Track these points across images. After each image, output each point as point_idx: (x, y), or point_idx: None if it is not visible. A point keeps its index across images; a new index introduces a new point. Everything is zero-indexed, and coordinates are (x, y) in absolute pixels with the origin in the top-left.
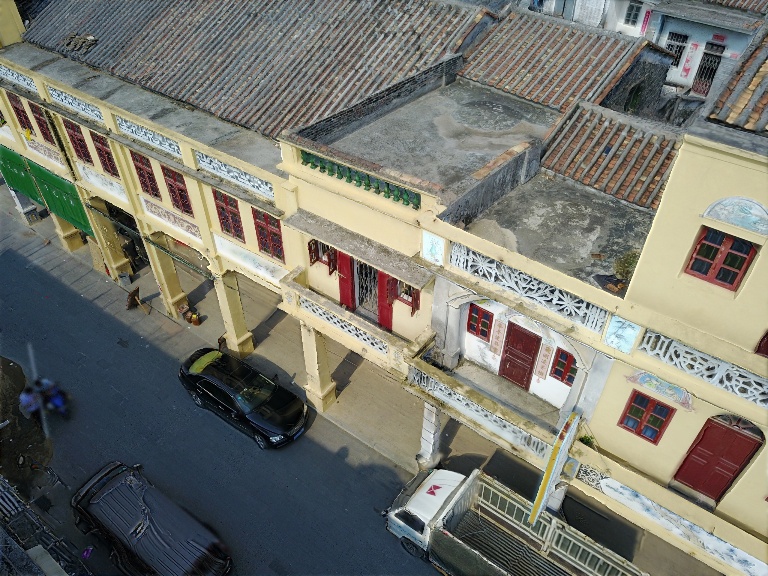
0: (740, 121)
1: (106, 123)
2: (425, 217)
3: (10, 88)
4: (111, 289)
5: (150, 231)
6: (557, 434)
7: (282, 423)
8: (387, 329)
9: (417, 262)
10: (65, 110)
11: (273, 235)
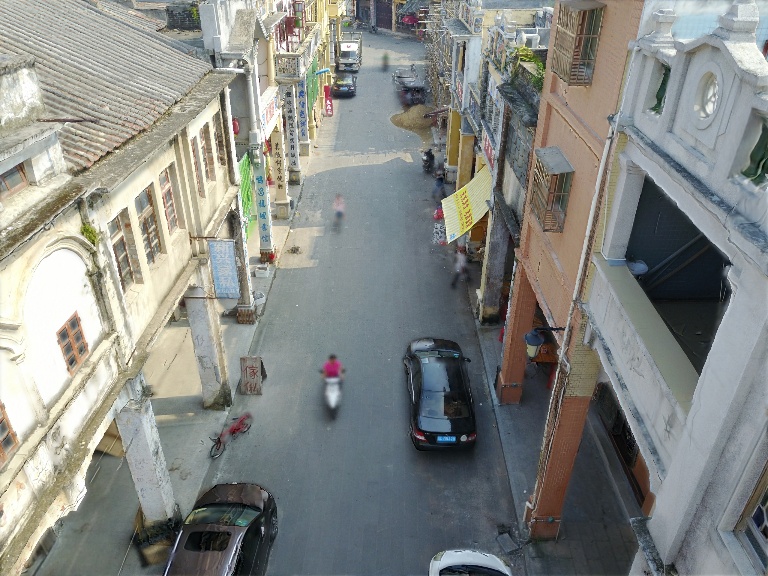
0: None
1: None
2: None
3: (312, 0)
4: None
5: None
6: None
7: None
8: None
9: None
10: None
11: None
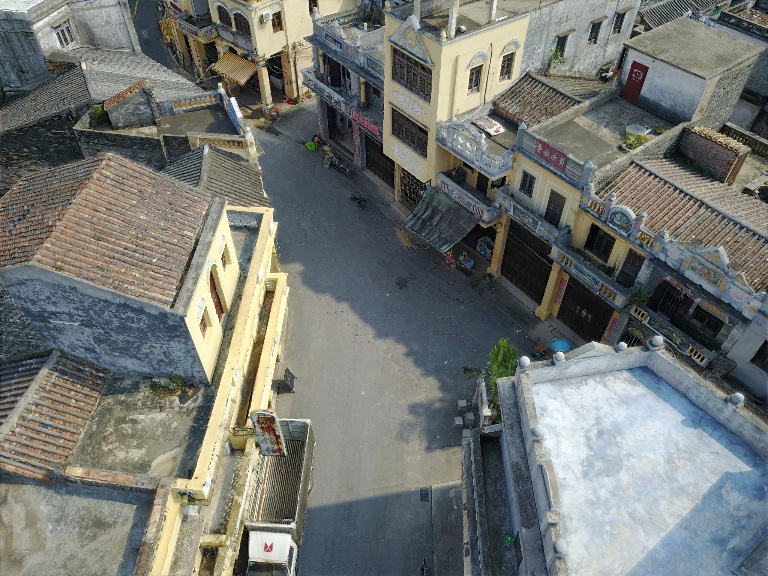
0: (172, 297)
1: None
2: (195, 485)
3: None
4: None
5: None
6: (233, 453)
7: None
8: None
9: None
10: None
11: None
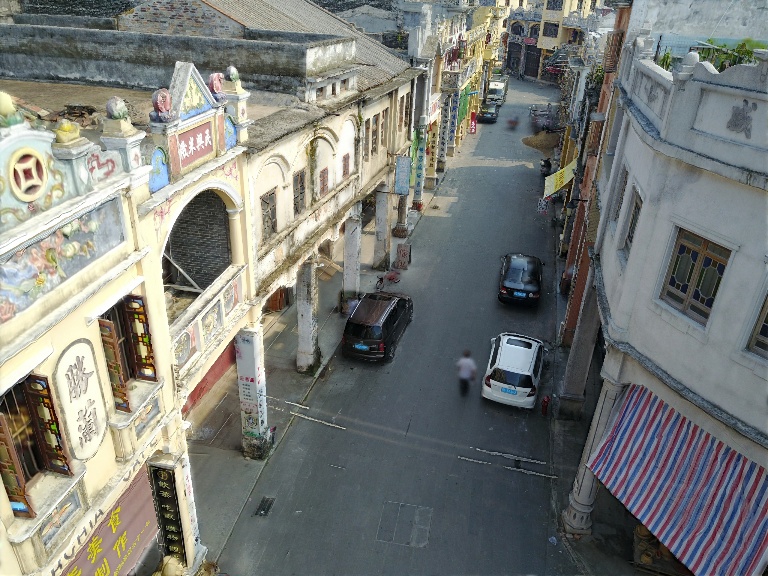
0: None
1: None
2: None
3: None
4: None
5: None
6: None
7: None
8: None
9: None
10: None
11: None
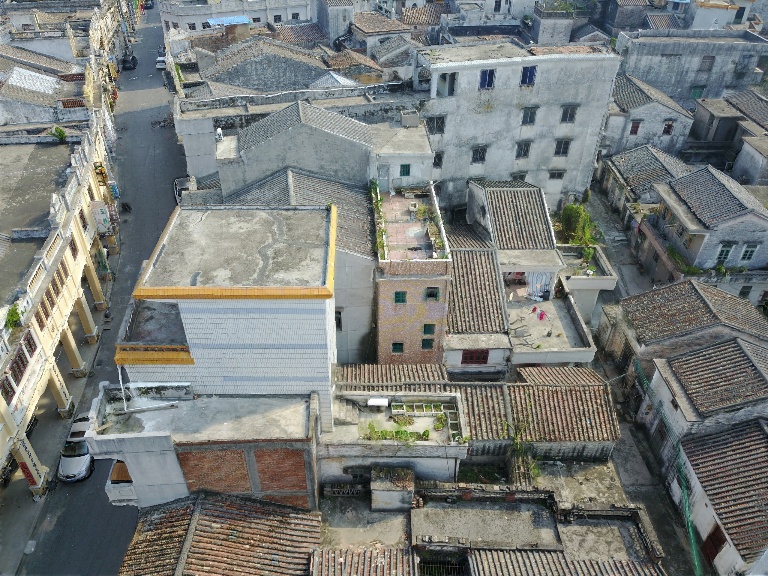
0: None
1: None
2: None
3: None
4: None
5: None
6: None
7: None
8: None
9: None
10: None
11: None
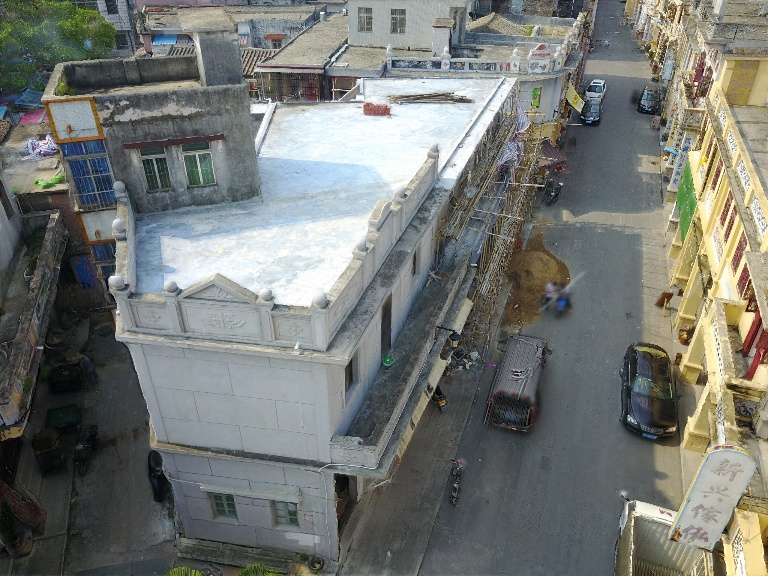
0: None
1: (733, 160)
2: None
3: (715, 124)
4: (662, 290)
5: (705, 252)
6: None
7: (647, 420)
8: (748, 378)
9: (765, 293)
10: (725, 146)
11: (748, 274)
